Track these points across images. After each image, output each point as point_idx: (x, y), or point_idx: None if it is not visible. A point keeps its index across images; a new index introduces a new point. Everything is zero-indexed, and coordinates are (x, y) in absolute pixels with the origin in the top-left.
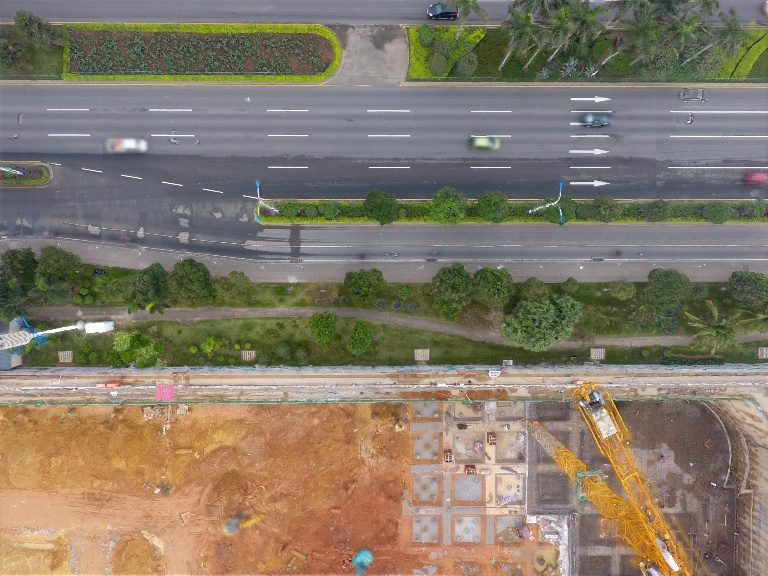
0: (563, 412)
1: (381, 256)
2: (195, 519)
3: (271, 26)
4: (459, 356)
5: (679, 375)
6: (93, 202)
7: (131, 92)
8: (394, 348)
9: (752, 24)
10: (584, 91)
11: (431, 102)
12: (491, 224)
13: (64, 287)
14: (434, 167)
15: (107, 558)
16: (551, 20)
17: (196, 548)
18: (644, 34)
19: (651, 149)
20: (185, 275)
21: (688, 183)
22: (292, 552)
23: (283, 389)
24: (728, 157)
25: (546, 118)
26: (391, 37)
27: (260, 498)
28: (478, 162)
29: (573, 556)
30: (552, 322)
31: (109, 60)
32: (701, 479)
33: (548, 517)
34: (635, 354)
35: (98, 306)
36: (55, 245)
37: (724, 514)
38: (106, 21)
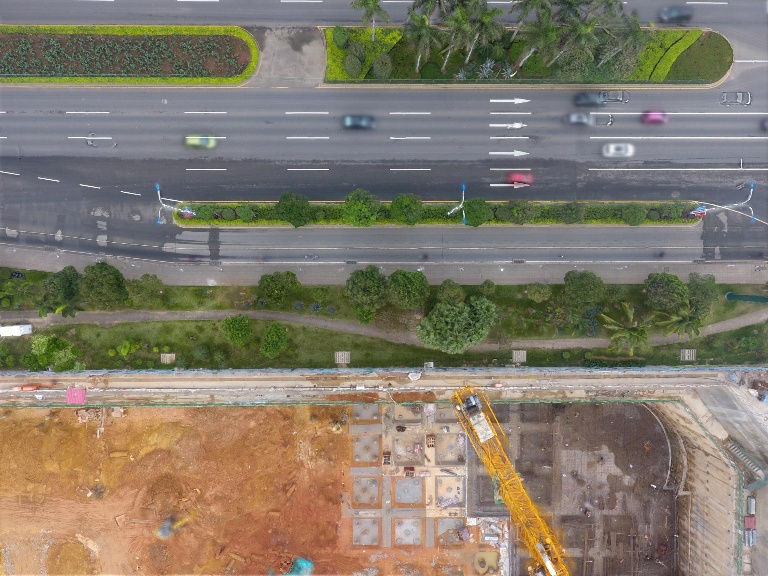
0: (503, 414)
1: (301, 258)
2: (130, 522)
3: (187, 28)
4: (380, 359)
5: (601, 377)
6: (10, 205)
7: (47, 94)
8: (314, 351)
9: (672, 25)
10: (503, 93)
11: (350, 104)
12: (411, 226)
13: None
14: (353, 169)
15: (41, 561)
16: (447, 22)
17: (131, 551)
18: (545, 36)
19: (571, 151)
20: (95, 278)
21: (609, 185)
22: (230, 555)
23: (203, 392)
24: (649, 159)
25: (465, 120)
26: (309, 39)
27: (195, 501)
28: (397, 164)
29: (513, 558)
30: (466, 324)
31: (24, 62)
32: (641, 481)
33: (489, 519)
34: (557, 356)
35: (16, 309)
36: None
37: (664, 516)
38: (22, 23)
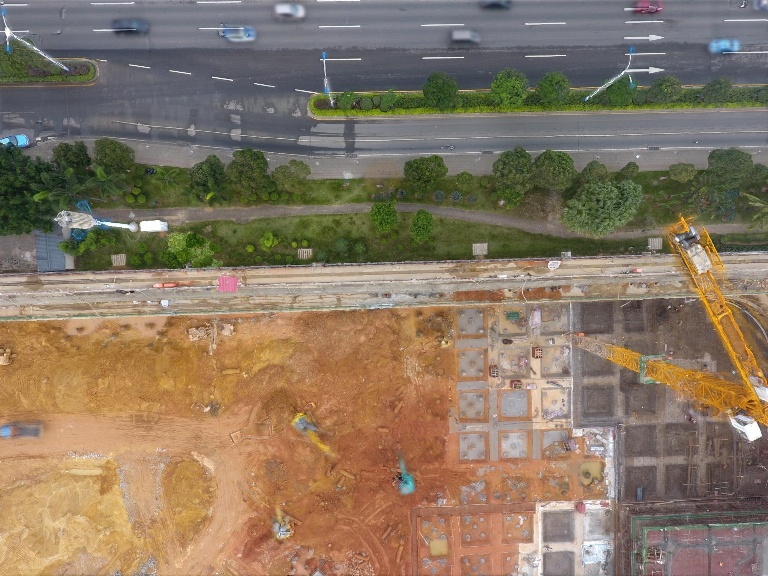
0: (606, 325)
1: (437, 149)
2: (245, 438)
3: None
4: (517, 249)
5: (736, 262)
6: (141, 99)
7: None
8: (452, 243)
9: None
10: None
11: None
12: (547, 114)
13: (121, 178)
14: (488, 56)
15: (157, 481)
16: None
17: (247, 468)
18: None
19: (705, 34)
20: (245, 163)
21: (742, 68)
22: (341, 472)
23: (341, 288)
24: None
25: (600, 4)
26: None
27: (310, 415)
28: (533, 51)
29: (619, 467)
30: (615, 204)
31: None
32: None
33: (593, 430)
34: None
35: (150, 207)
36: None
37: None
38: None
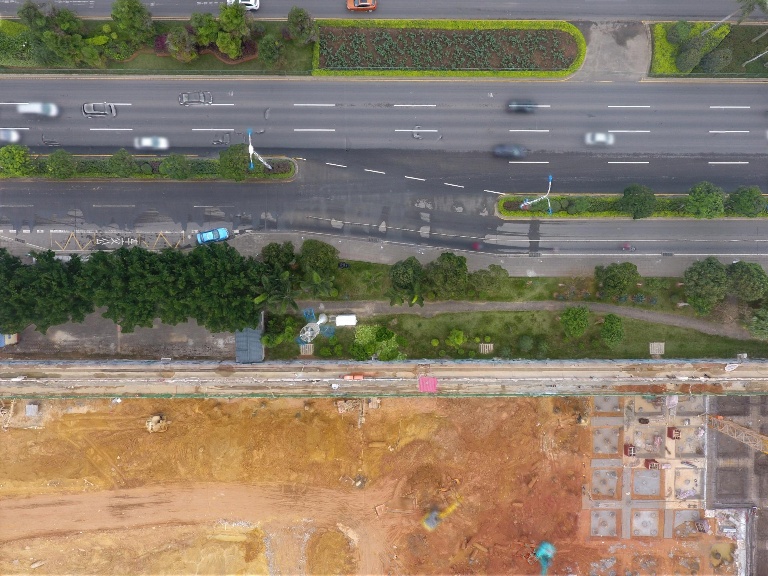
0: (742, 407)
1: (618, 250)
2: (389, 512)
3: (518, 22)
4: (694, 350)
5: None
6: (336, 196)
7: (377, 88)
8: (629, 342)
9: None
10: None
11: (671, 98)
12: (728, 219)
13: None
14: (673, 162)
15: (302, 550)
16: None
17: (389, 540)
18: None
19: None
20: (449, 268)
21: None
22: (475, 545)
23: (519, 382)
24: None
25: None
26: (633, 33)
27: (454, 491)
28: (716, 157)
29: (752, 550)
30: None
31: (358, 56)
32: None
33: (725, 511)
34: None
35: (340, 299)
36: (299, 239)
37: None
38: (354, 17)
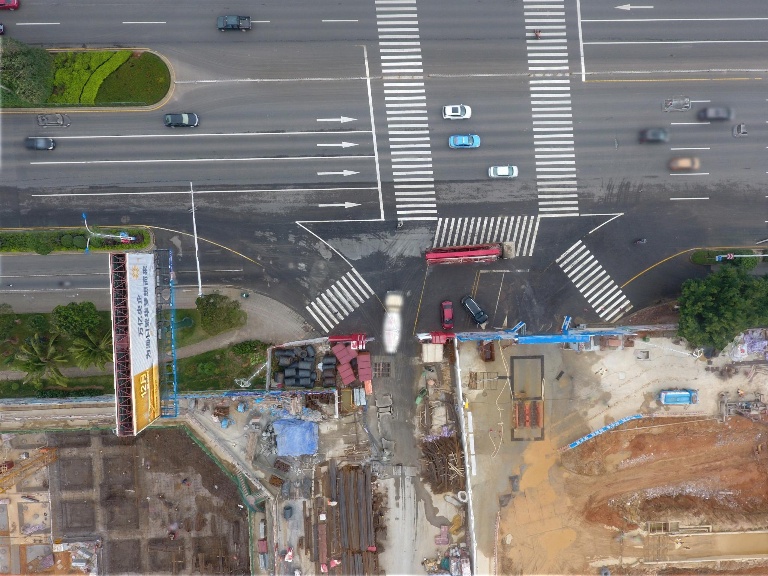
0: (87, 438)
1: None
2: None
3: None
4: None
5: (56, 408)
6: None
7: None
8: None
9: (108, 46)
10: None
11: None
12: None
13: None
14: None
15: None
16: None
17: None
18: None
19: (12, 177)
20: None
21: (54, 211)
22: None
23: None
24: (94, 183)
25: None
26: None
27: None
28: None
29: None
30: None
31: None
32: (228, 501)
33: (79, 544)
34: (10, 387)
35: None
36: None
37: None
38: None
